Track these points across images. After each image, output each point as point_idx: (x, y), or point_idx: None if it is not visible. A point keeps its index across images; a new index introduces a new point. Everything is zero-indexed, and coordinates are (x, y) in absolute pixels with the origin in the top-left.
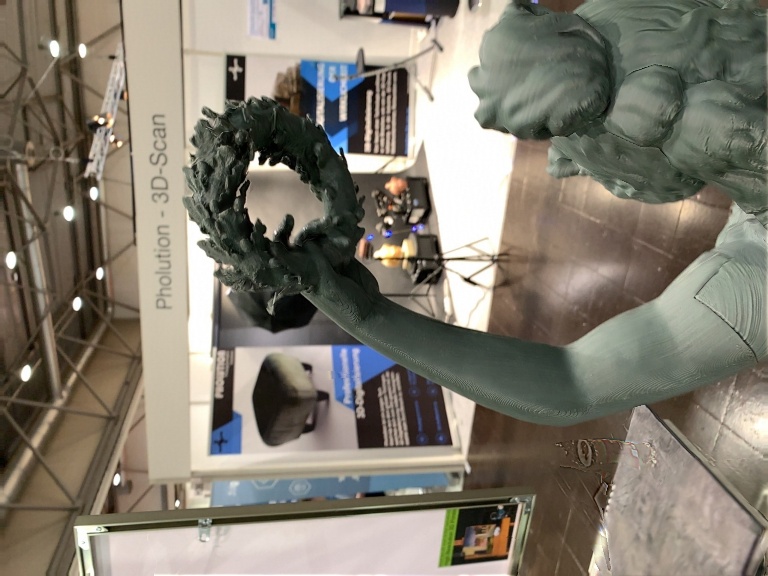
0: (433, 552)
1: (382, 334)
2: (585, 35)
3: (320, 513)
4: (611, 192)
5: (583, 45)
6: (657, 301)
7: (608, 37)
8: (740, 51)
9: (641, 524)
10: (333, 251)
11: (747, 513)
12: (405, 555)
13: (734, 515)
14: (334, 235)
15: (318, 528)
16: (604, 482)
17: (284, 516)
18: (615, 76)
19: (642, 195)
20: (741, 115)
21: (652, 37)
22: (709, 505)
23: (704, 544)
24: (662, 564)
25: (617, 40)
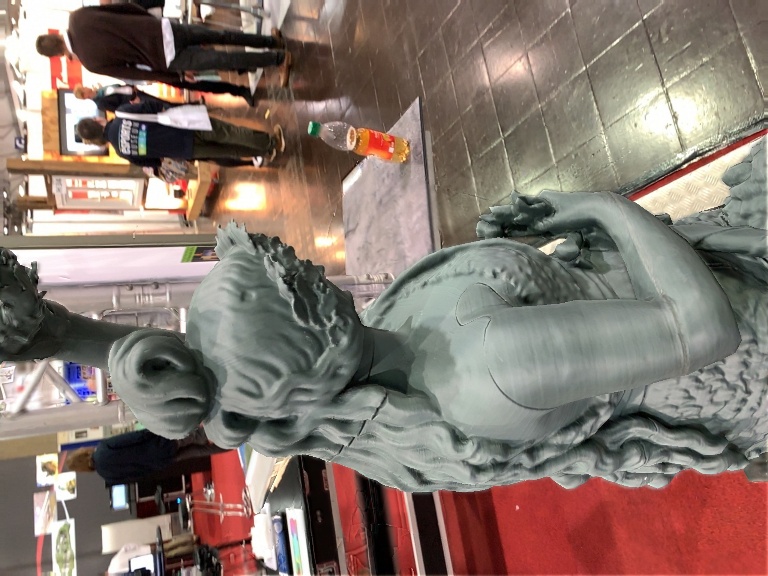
0: (176, 258)
1: (70, 360)
2: (189, 399)
3: (72, 247)
4: None
5: (183, 409)
6: None
7: (218, 378)
8: (306, 406)
9: (380, 189)
10: (15, 344)
11: (431, 241)
12: (152, 259)
13: (425, 236)
14: (15, 334)
15: (72, 251)
16: (360, 162)
17: (38, 247)
18: (214, 404)
19: None
20: (279, 454)
21: (243, 399)
22: (417, 217)
23: (404, 235)
24: (379, 224)
25: (223, 384)
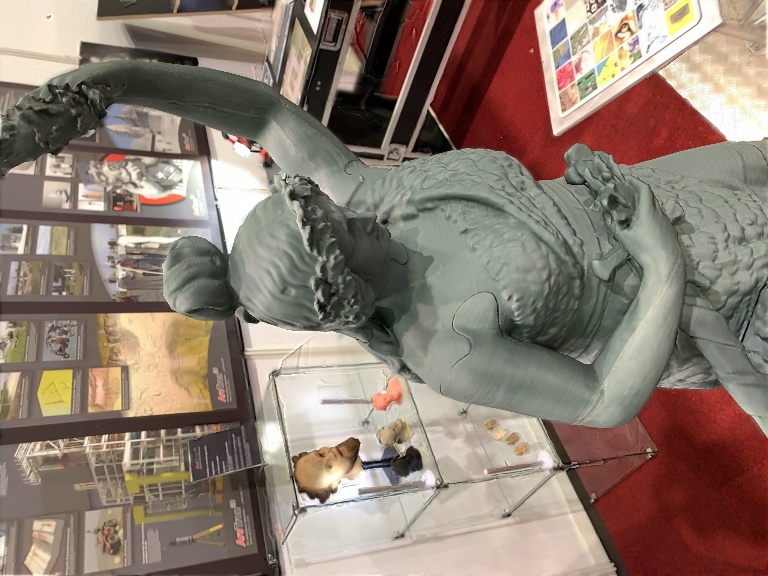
0: None
1: None
2: None
3: None
4: None
5: None
6: (317, 174)
7: (247, 308)
8: None
9: None
10: None
11: None
12: None
13: None
14: None
15: None
16: None
17: None
18: None
19: None
20: None
21: None
22: None
23: None
24: None
25: None
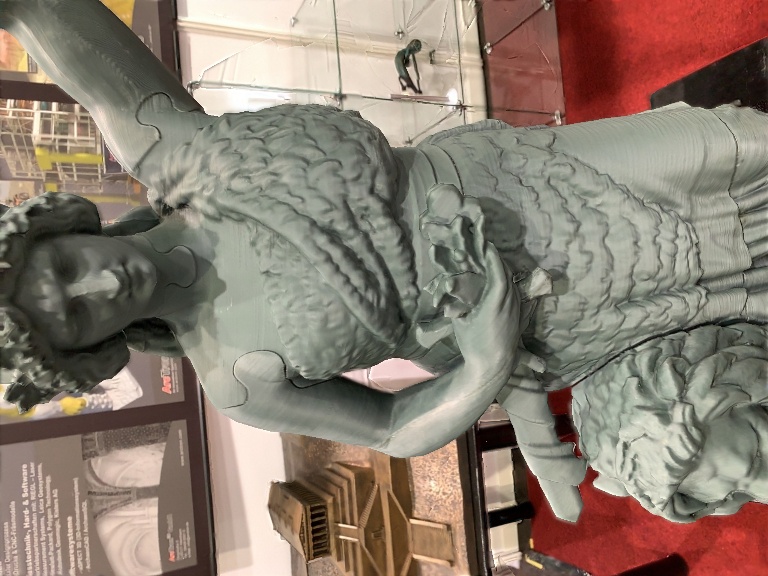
0: None
1: None
2: None
3: None
4: None
5: None
6: (98, 110)
7: None
8: None
9: None
10: None
11: None
12: None
13: None
14: None
15: None
16: None
17: None
18: None
19: None
20: None
21: None
22: None
23: None
24: None
25: None
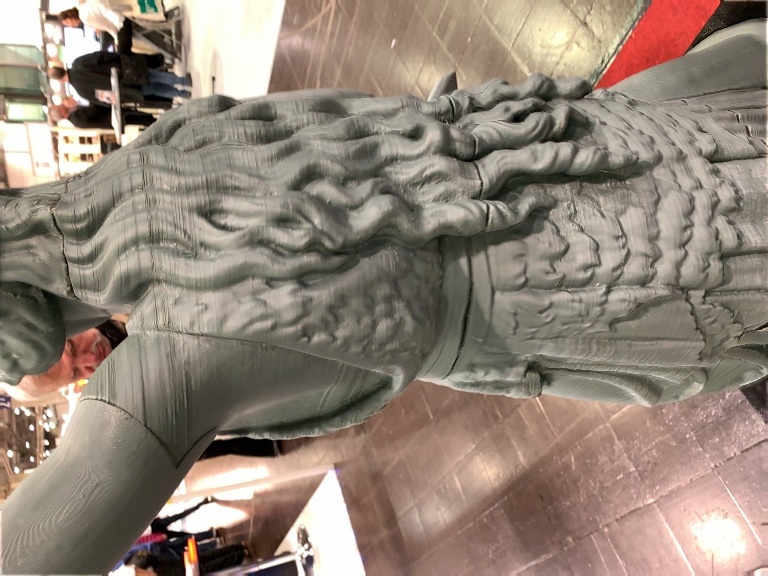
0: None
1: None
2: None
3: None
4: (2, 373)
5: None
6: None
7: None
8: None
9: None
10: None
11: None
12: None
13: None
14: None
15: None
16: None
17: None
18: None
19: (5, 346)
20: None
21: None
22: None
23: None
24: None
25: None
